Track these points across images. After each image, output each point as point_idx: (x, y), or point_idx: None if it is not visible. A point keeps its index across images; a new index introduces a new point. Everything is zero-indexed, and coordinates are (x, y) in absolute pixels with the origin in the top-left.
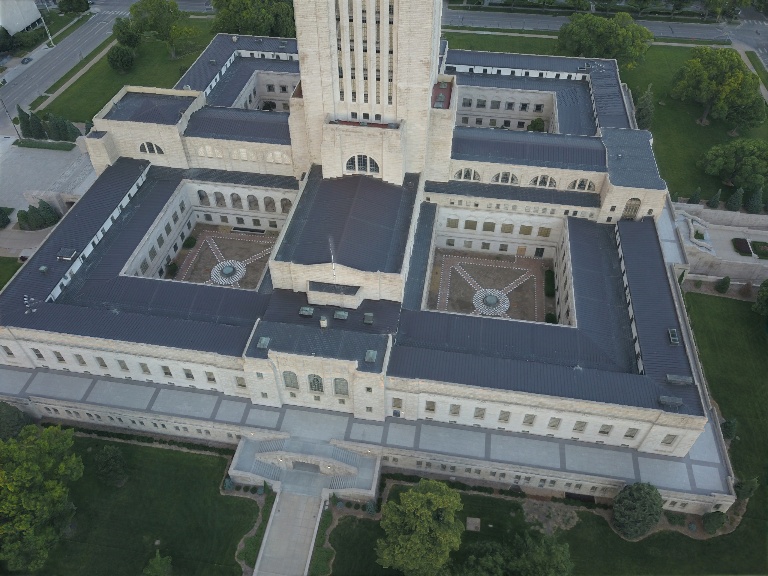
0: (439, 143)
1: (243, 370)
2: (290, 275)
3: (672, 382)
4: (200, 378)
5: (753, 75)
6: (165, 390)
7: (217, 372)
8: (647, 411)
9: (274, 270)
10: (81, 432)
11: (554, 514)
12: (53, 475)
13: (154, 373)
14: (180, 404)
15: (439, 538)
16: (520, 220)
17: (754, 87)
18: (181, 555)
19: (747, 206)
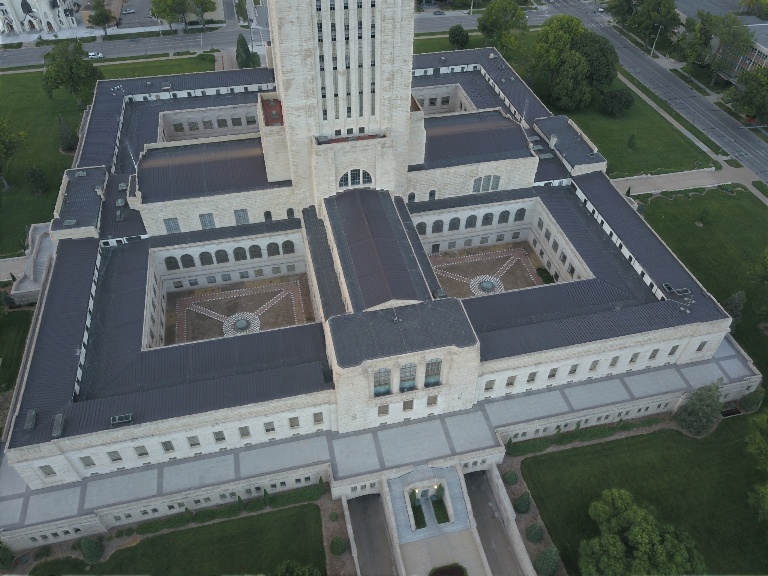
0: None
1: None
2: None
3: None
4: None
5: None
6: None
7: None
8: None
9: None
10: None
11: (1, 412)
12: None
13: None
14: None
15: None
16: None
17: None
18: None
19: None
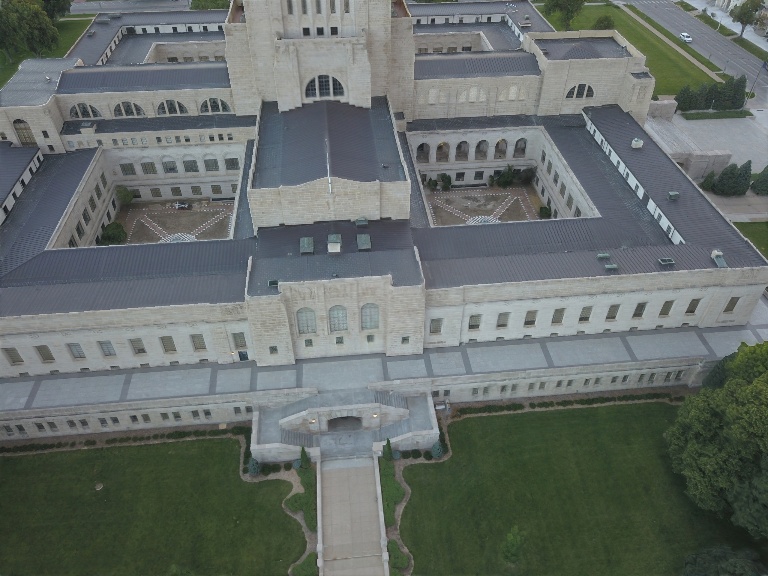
0: None
1: None
2: None
3: None
4: None
5: None
6: None
7: None
8: None
9: None
10: None
11: None
12: None
13: None
14: None
15: None
16: None
17: None
18: None
19: None
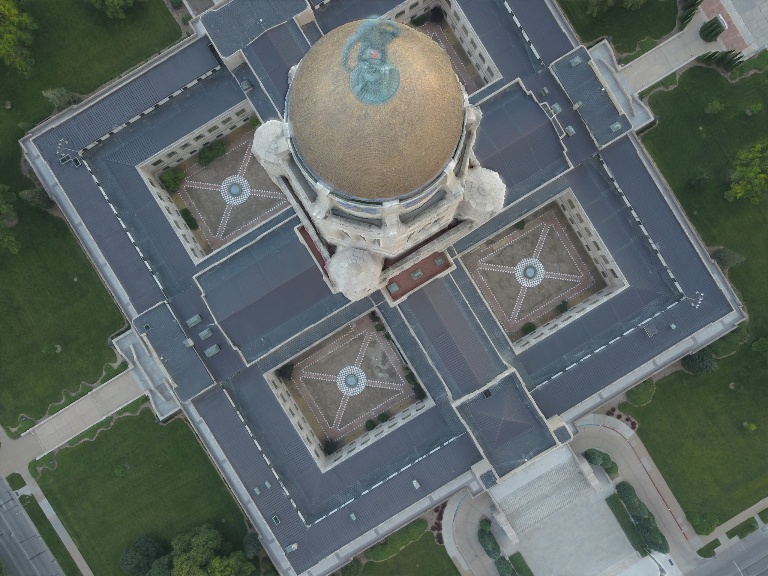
0: None
1: None
2: None
3: None
4: None
5: None
6: None
7: None
8: None
9: None
10: None
11: None
12: None
13: None
14: None
15: None
16: None
17: None
18: (697, 111)
19: None
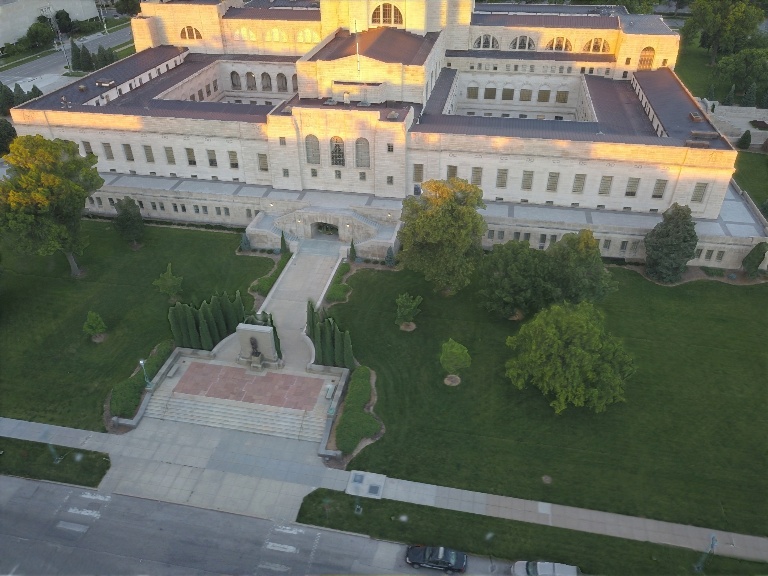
0: (459, 4)
1: (266, 140)
2: (316, 78)
3: (697, 137)
4: (223, 163)
5: (756, 7)
6: (188, 181)
7: (240, 150)
8: (673, 149)
9: (301, 73)
10: (101, 219)
11: None
12: (73, 180)
13: (178, 162)
14: (201, 188)
15: (462, 209)
16: (538, 83)
17: (758, 17)
18: (192, 290)
19: (762, 103)
